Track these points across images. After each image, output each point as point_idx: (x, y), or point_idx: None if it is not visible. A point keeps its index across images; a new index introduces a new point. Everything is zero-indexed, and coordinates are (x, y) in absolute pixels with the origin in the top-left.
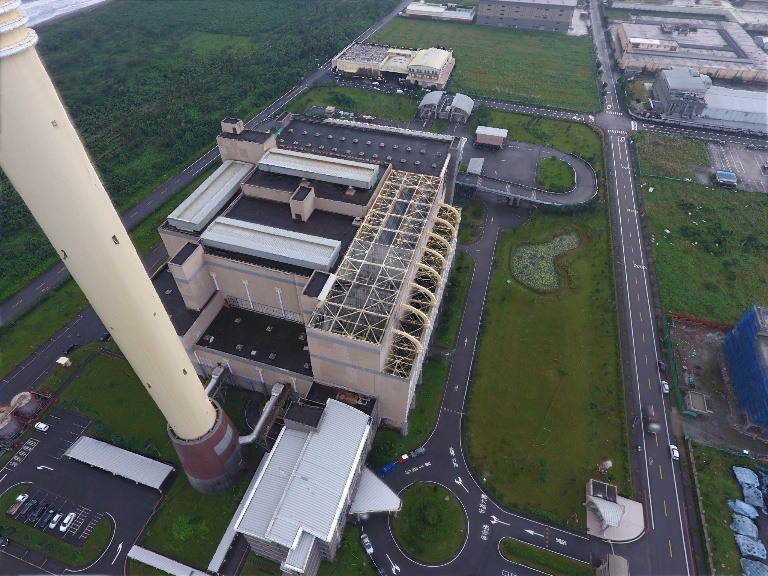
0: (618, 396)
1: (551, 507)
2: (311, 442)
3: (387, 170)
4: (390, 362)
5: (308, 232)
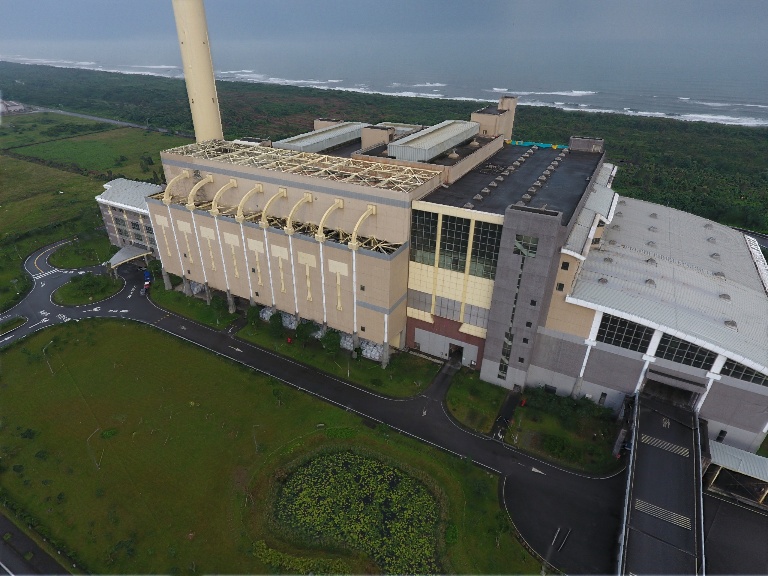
0: (4, 487)
1: (3, 357)
2: (158, 188)
3: (433, 164)
4: (174, 195)
5: (344, 154)
